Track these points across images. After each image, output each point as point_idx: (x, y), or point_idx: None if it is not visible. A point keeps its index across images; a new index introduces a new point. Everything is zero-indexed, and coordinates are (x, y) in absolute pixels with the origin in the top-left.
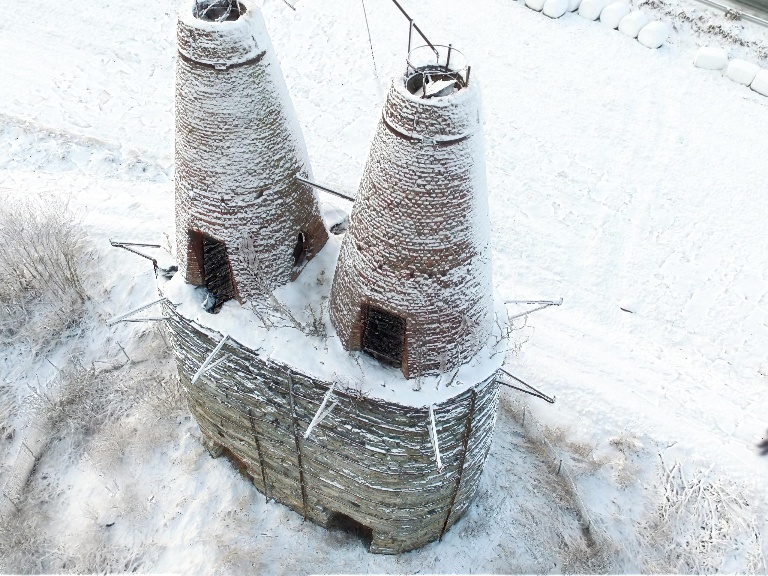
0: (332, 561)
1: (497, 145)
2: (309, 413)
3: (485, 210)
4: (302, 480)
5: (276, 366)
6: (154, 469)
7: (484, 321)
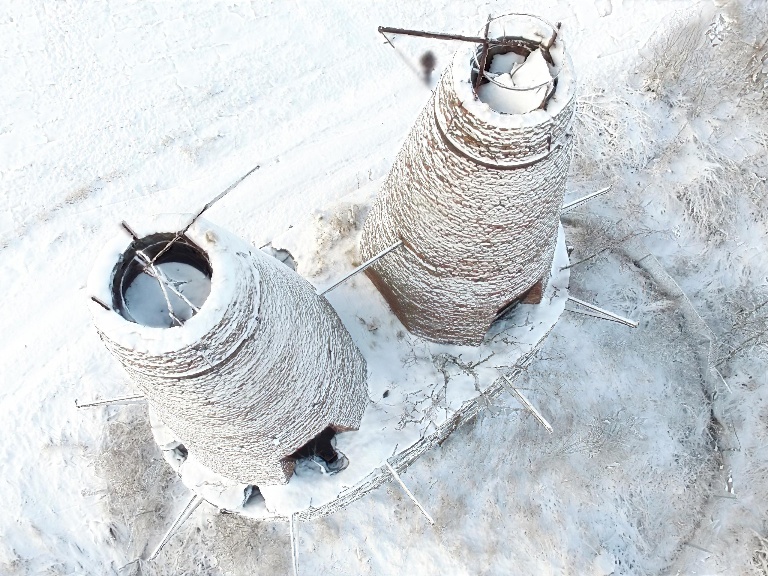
0: (482, 436)
1: (108, 4)
2: None
3: None
4: None
5: None
6: (307, 572)
7: None
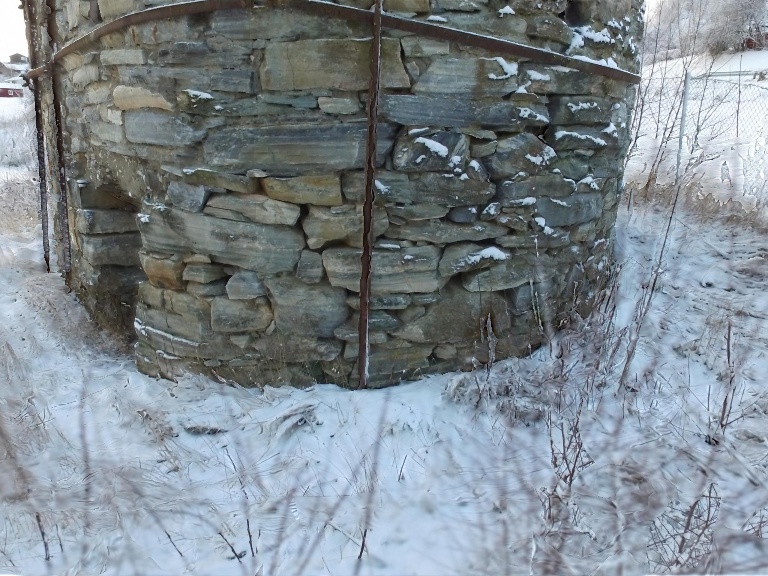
0: (28, 367)
1: None
2: None
3: None
4: (54, 33)
5: None
6: None
7: None
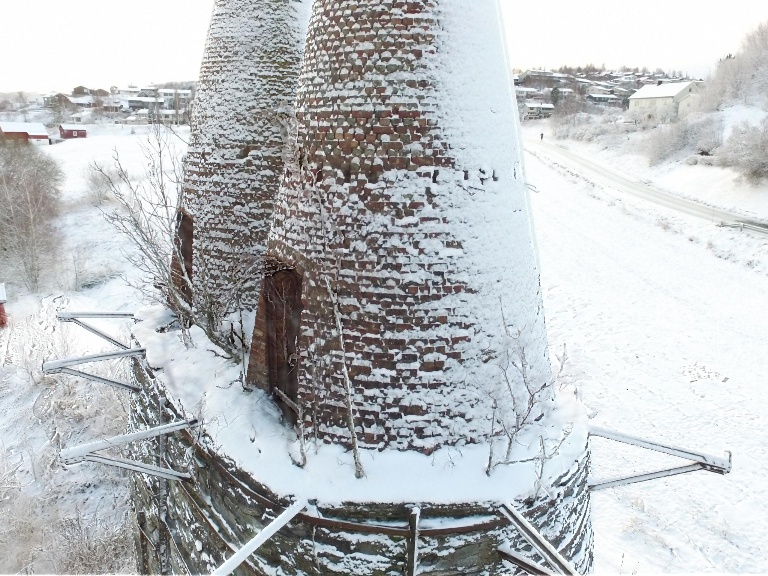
0: None
1: None
2: (178, 516)
3: (483, 89)
4: None
5: (158, 392)
6: None
7: (483, 371)
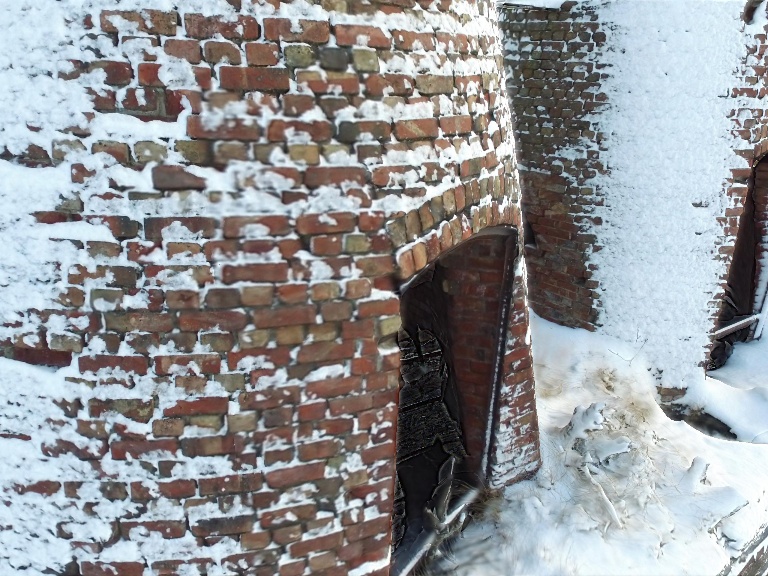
0: None
1: None
2: None
3: None
4: None
5: None
6: None
7: None
